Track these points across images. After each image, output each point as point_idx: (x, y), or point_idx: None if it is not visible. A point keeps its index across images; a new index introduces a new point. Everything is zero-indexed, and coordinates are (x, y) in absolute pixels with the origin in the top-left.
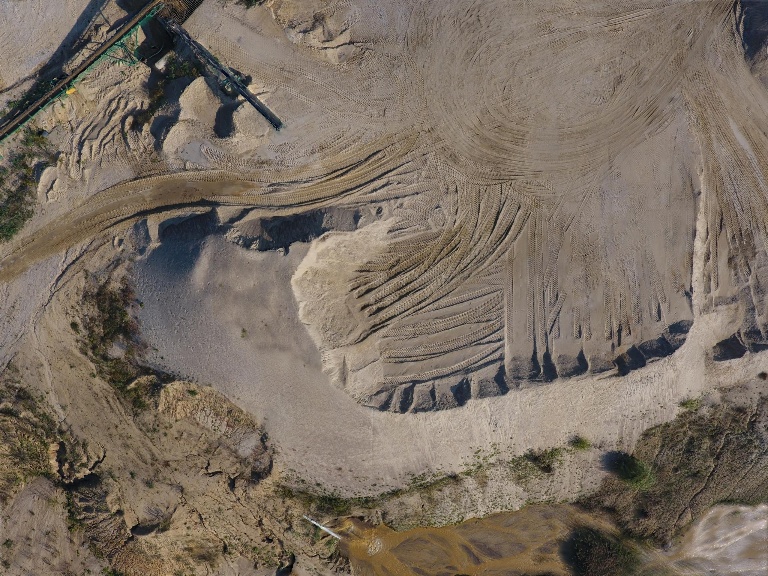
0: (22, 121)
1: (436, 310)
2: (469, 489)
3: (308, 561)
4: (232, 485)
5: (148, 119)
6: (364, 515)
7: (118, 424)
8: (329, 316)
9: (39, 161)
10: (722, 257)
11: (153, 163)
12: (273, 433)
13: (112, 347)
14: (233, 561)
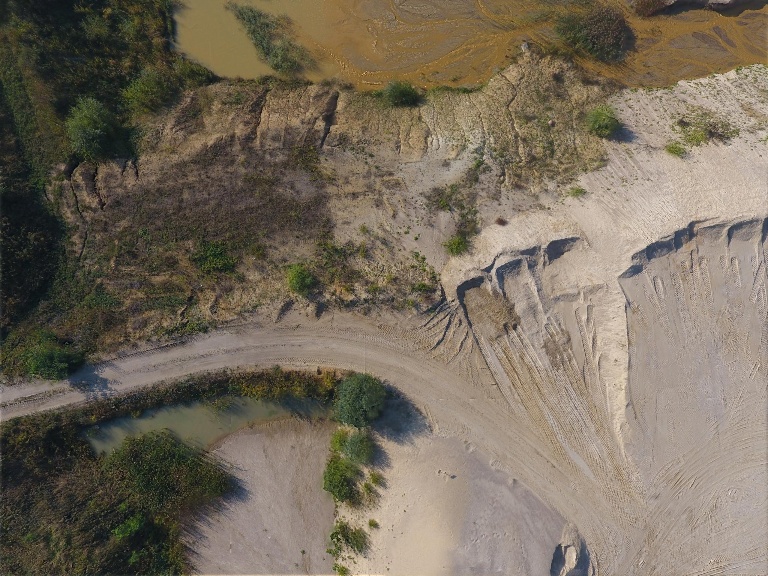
0: None
1: None
2: (760, 104)
3: None
4: None
5: None
6: None
7: None
8: None
9: None
10: (577, 342)
11: None
12: None
13: None
14: None
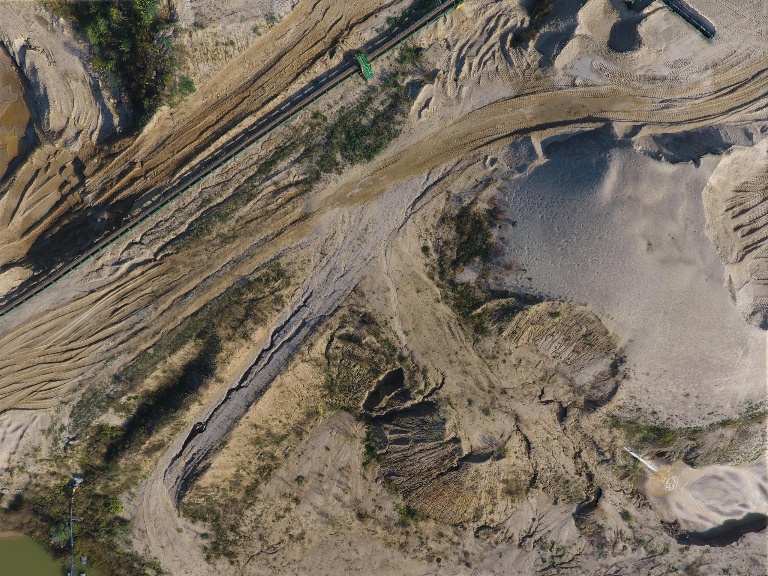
0: (405, 37)
1: None
2: None
3: (614, 496)
4: (562, 414)
5: (534, 35)
6: (669, 450)
7: (458, 350)
8: (715, 234)
9: (413, 79)
10: None
11: (537, 80)
12: (633, 356)
13: (463, 271)
14: (533, 497)
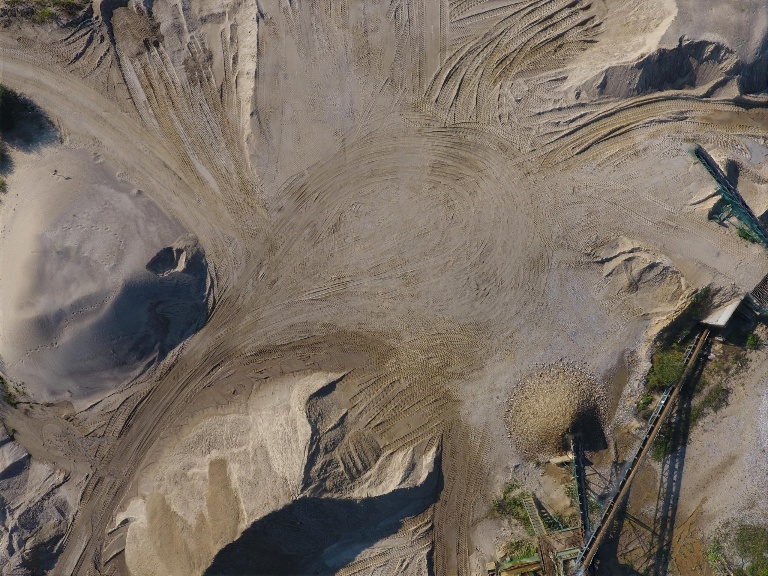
0: None
1: (517, 3)
2: None
3: None
4: None
5: None
6: None
7: None
8: None
9: None
10: (219, 61)
11: None
12: None
13: None
14: None
